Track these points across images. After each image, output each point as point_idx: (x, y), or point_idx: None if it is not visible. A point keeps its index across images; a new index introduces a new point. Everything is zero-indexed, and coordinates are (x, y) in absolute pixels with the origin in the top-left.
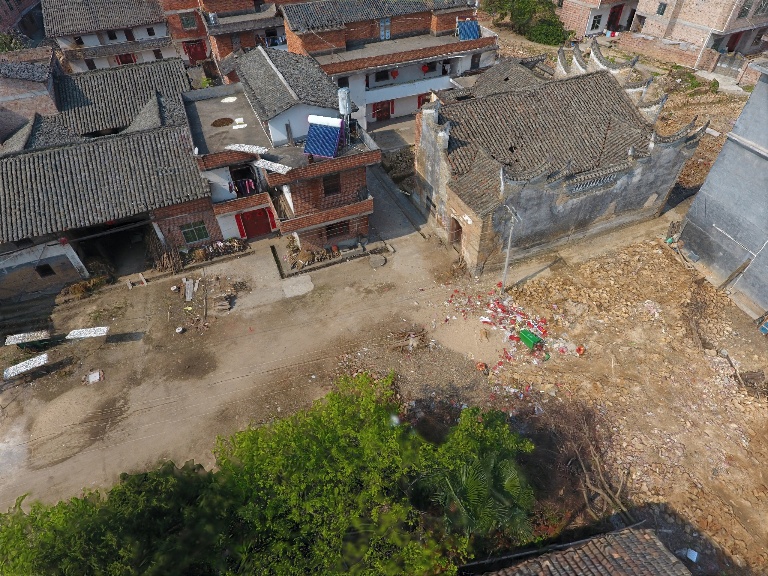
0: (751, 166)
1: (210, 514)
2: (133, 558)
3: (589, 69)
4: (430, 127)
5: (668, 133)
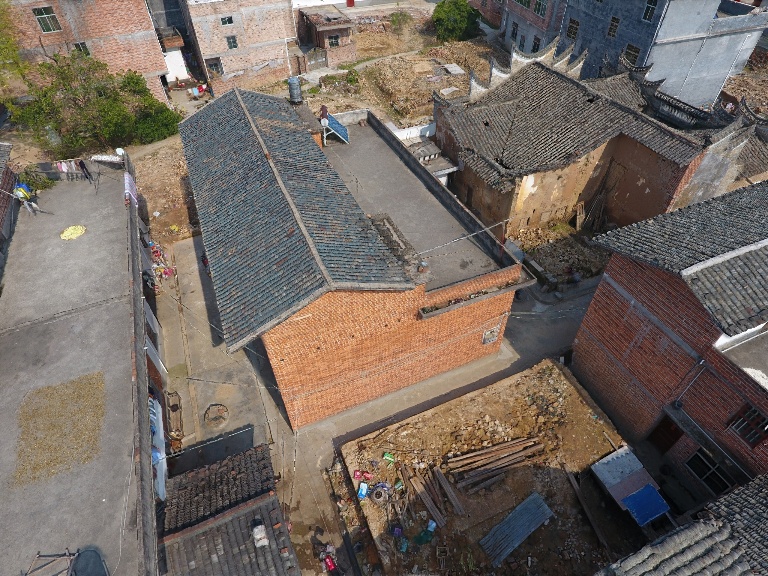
0: None
1: None
2: None
3: (514, 71)
4: (719, 153)
5: None
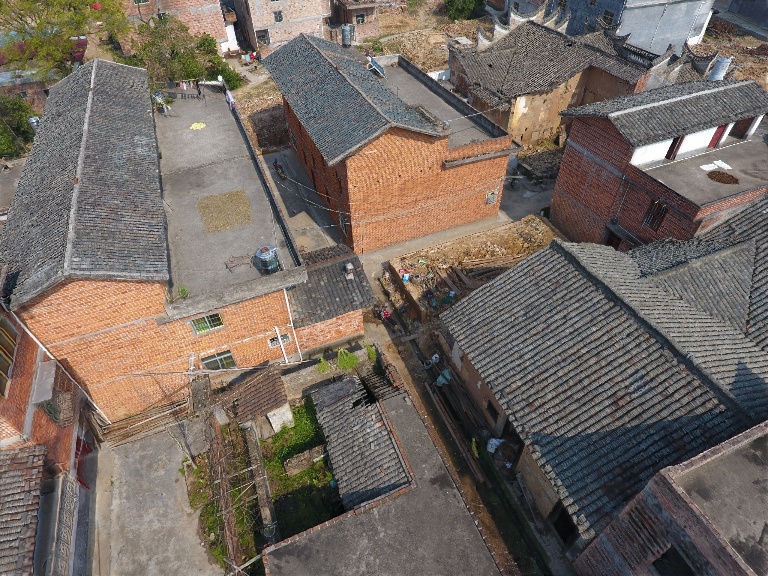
0: (639, 15)
1: None
2: None
3: (512, 28)
4: (660, 75)
5: None
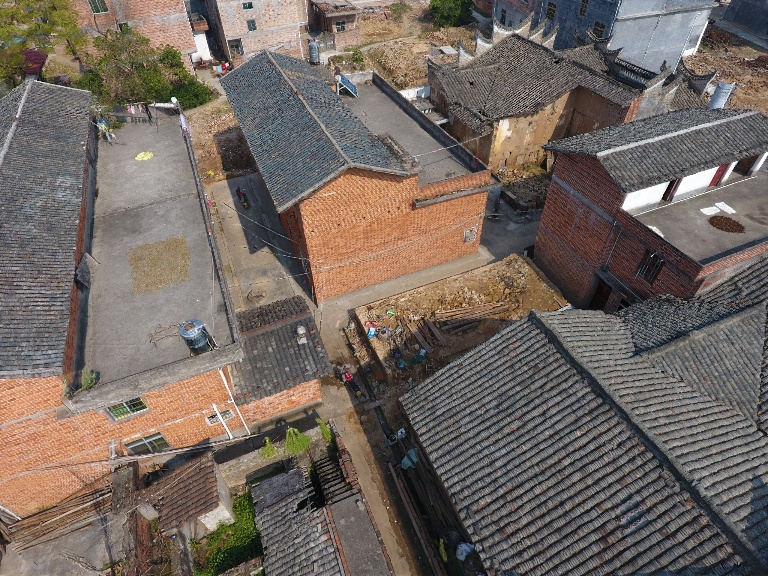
0: (631, 27)
1: None
2: None
3: (496, 41)
4: (654, 97)
5: None
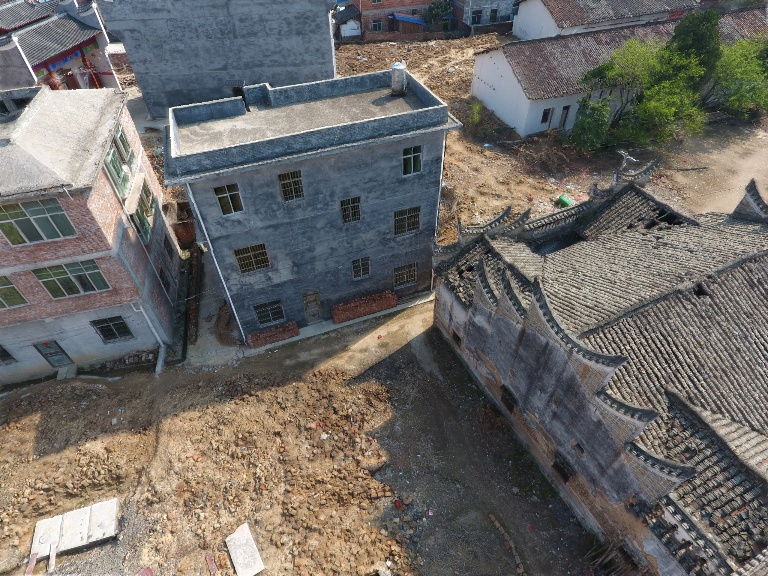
0: None
1: (684, 39)
2: (694, 21)
3: None
4: None
5: (331, 551)
